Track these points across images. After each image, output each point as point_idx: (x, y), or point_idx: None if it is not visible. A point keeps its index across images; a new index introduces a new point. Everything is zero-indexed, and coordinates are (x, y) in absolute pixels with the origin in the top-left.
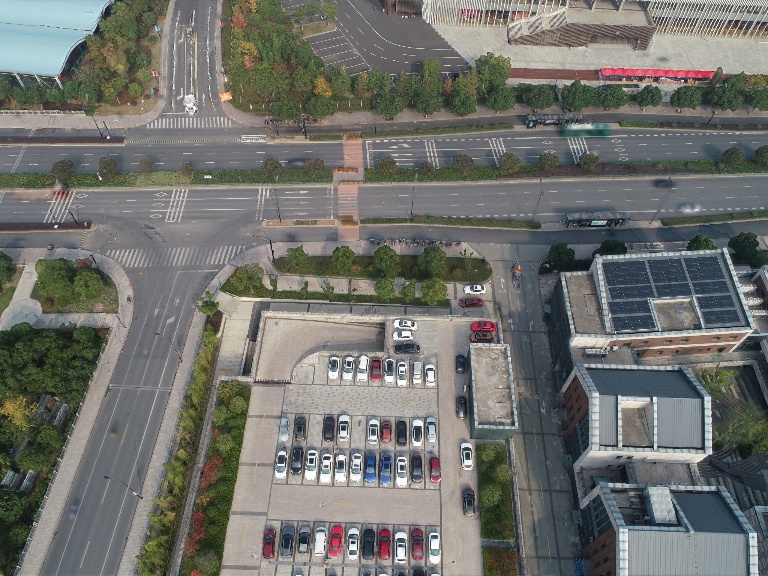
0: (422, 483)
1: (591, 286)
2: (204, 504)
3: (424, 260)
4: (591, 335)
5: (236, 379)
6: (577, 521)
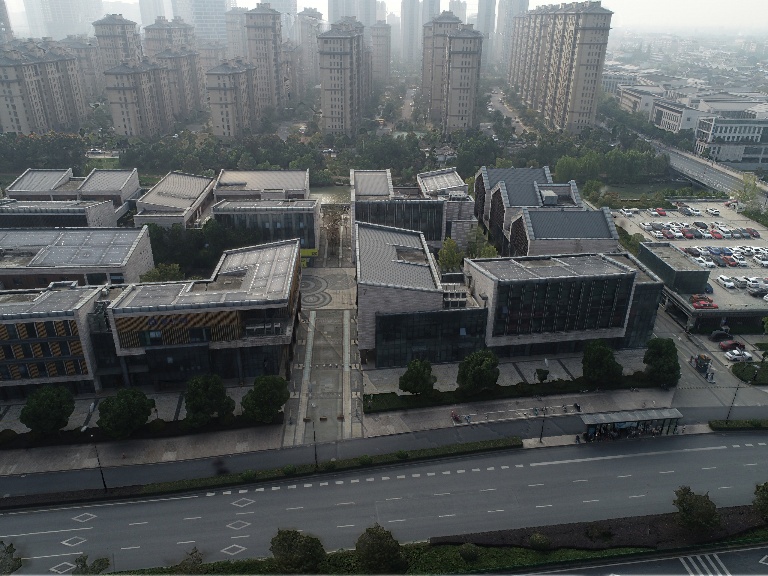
0: None
1: None
2: None
3: None
4: (613, 253)
5: None
6: None
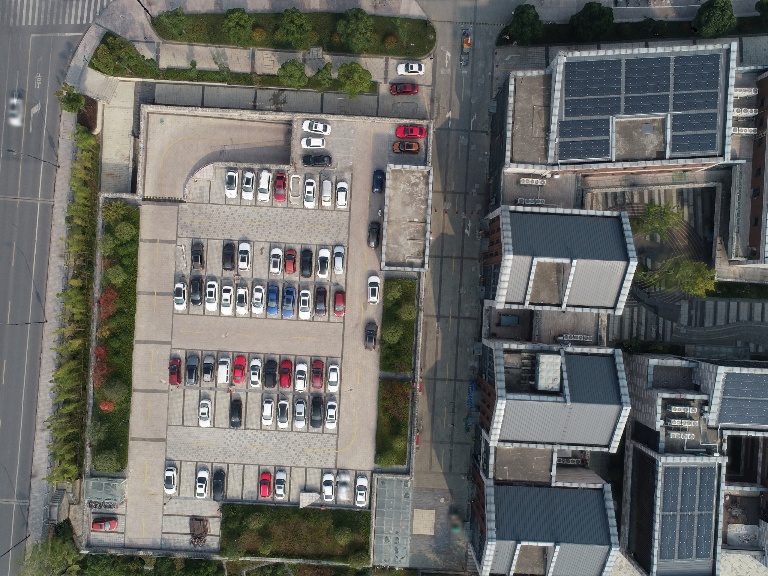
0: (326, 316)
1: (545, 93)
2: (105, 336)
3: (345, 30)
4: (528, 166)
5: (121, 197)
6: (477, 353)
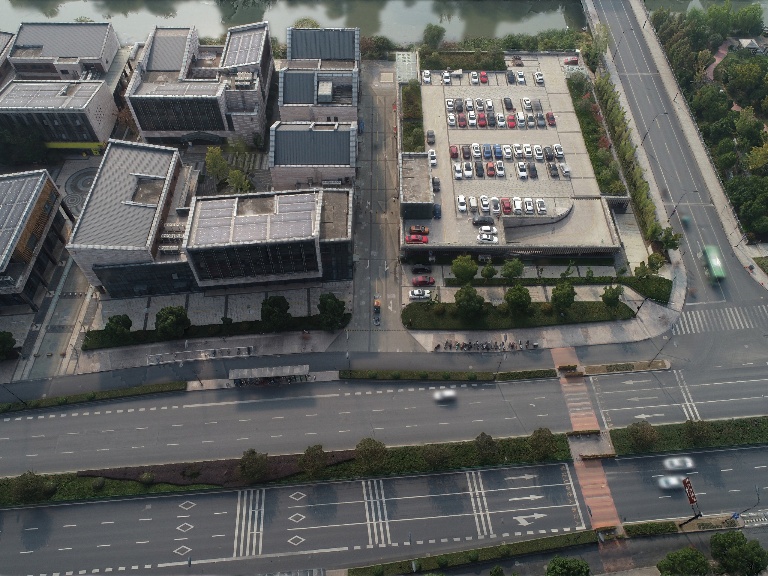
0: None
1: (324, 230)
2: None
3: None
4: (337, 189)
5: (616, 196)
6: (360, 138)
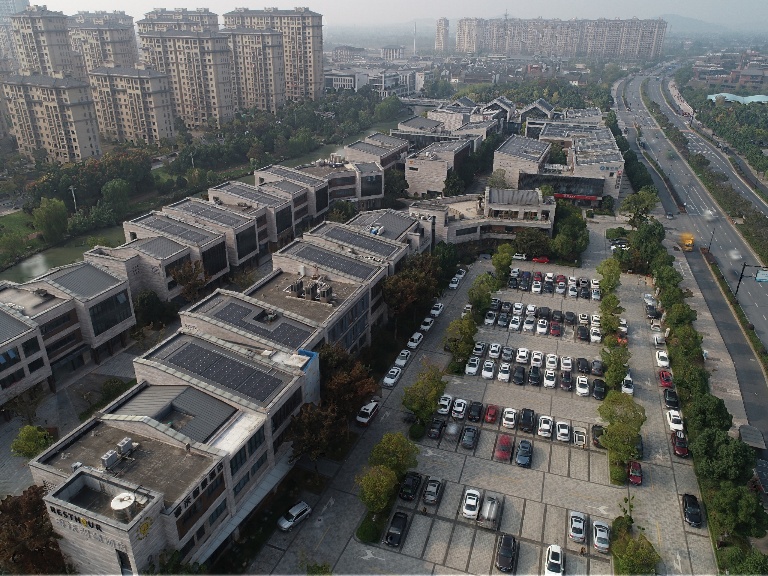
0: None
1: None
2: None
3: None
4: None
5: None
6: None
